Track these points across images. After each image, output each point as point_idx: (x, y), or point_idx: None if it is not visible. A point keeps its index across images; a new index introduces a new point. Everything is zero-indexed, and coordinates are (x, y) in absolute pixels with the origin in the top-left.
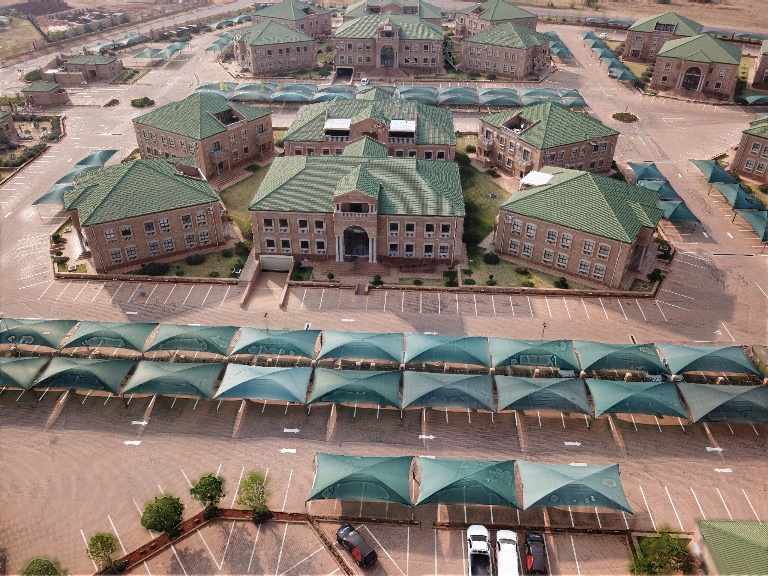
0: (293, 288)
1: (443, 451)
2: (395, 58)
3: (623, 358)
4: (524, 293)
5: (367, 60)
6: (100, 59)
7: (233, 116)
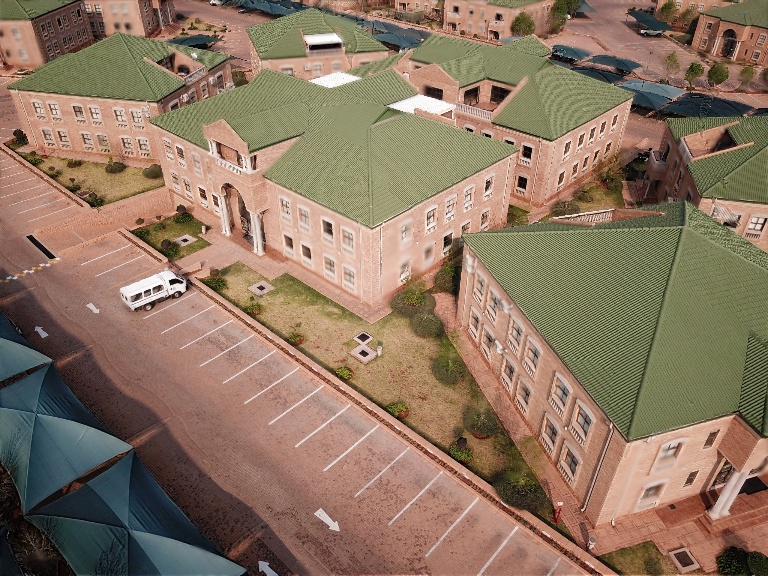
0: None
1: None
2: None
3: None
4: None
5: None
6: None
7: None
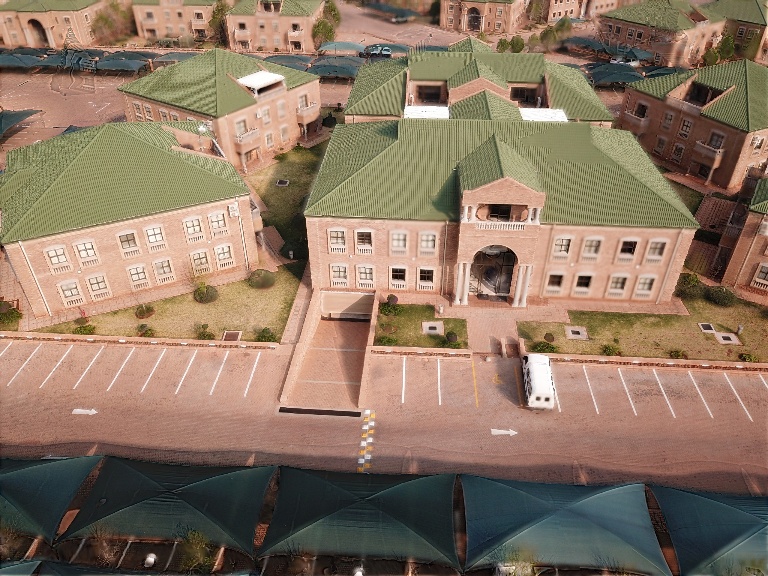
0: None
1: None
2: None
3: None
4: None
5: None
6: None
7: None
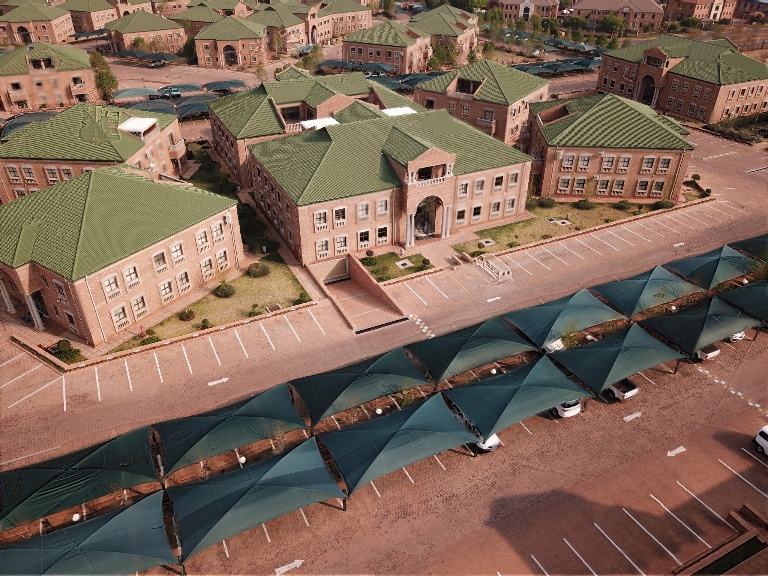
0: None
1: None
2: None
3: None
4: None
5: None
6: None
7: None
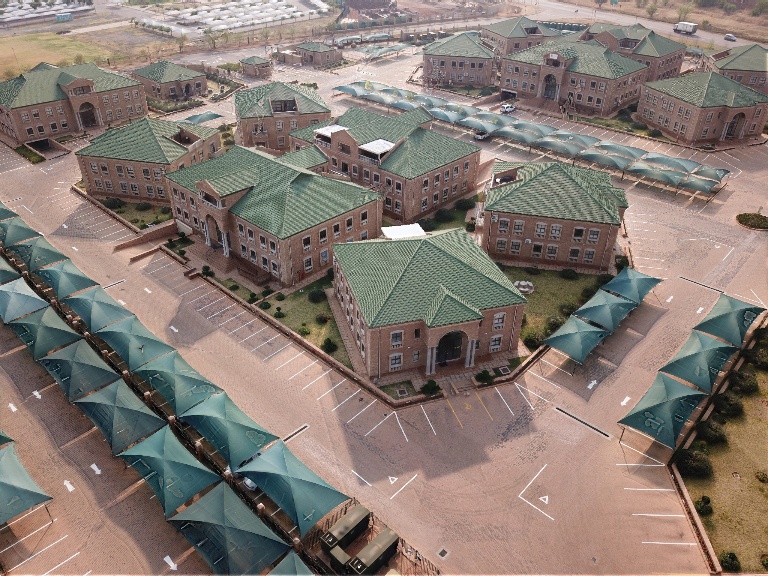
0: (160, 252)
1: (26, 410)
2: (557, 90)
3: (215, 427)
4: (293, 338)
5: (531, 87)
6: (319, 47)
7: (294, 106)
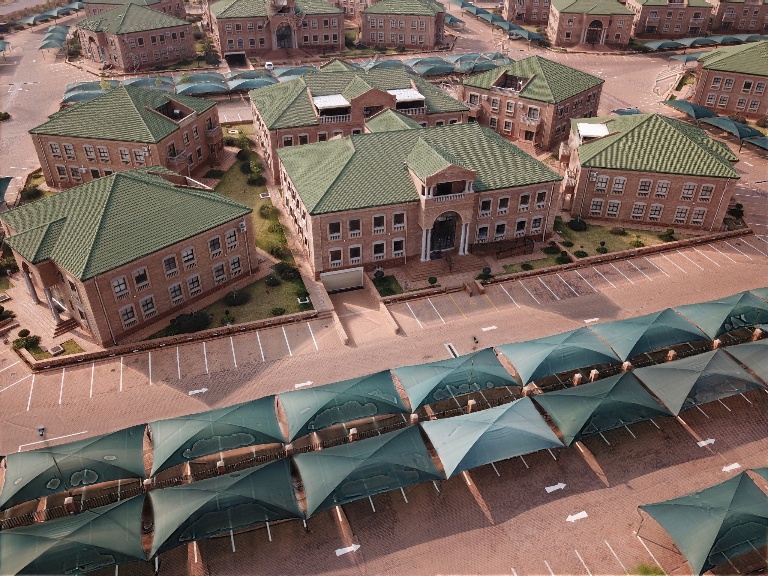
0: (391, 305)
1: (739, 453)
2: (293, 37)
3: None
4: (639, 254)
5: (260, 42)
6: None
7: (175, 110)
